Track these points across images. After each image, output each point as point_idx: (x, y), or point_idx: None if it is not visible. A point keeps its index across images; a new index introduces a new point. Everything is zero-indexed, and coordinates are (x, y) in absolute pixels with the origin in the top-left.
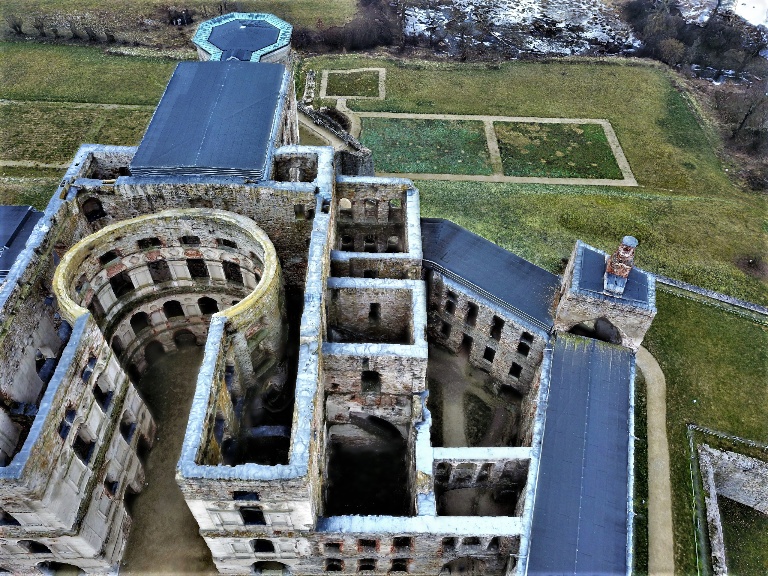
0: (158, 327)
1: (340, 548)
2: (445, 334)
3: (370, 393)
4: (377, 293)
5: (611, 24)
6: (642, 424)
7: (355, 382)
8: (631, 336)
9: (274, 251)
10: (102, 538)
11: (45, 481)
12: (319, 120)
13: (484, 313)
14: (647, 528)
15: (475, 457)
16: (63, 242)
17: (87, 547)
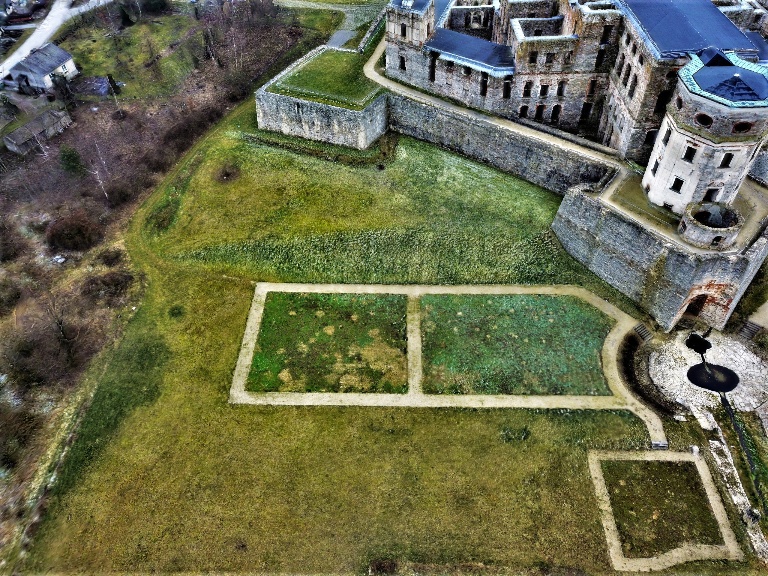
0: None
1: None
2: None
3: None
4: None
5: None
6: None
7: None
8: None
9: None
10: None
11: None
12: None
13: None
14: None
15: None
16: None
17: None
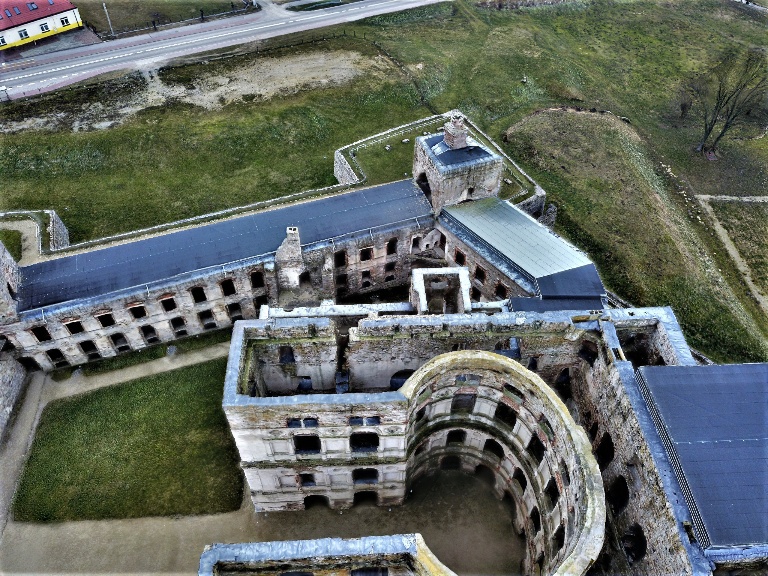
0: (504, 470)
1: None
2: None
3: None
4: None
5: None
6: None
7: None
8: None
9: None
10: (264, 489)
11: (245, 426)
12: None
13: None
14: None
15: None
16: (526, 342)
17: None
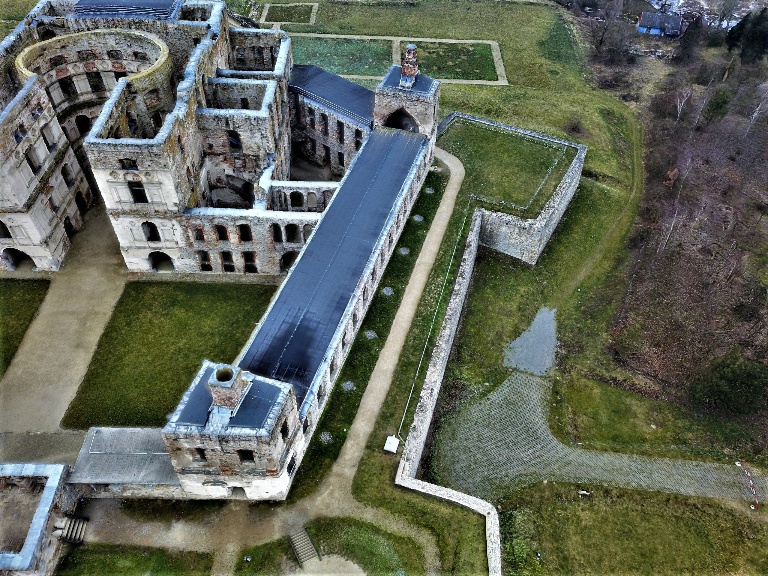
0: None
1: (204, 237)
2: (314, 151)
3: (236, 155)
4: (243, 88)
5: None
6: (439, 195)
7: (223, 142)
8: (423, 123)
9: (168, 50)
10: (46, 233)
11: (4, 158)
12: (244, 22)
13: (331, 121)
14: (423, 244)
15: (300, 185)
16: None
17: (35, 230)
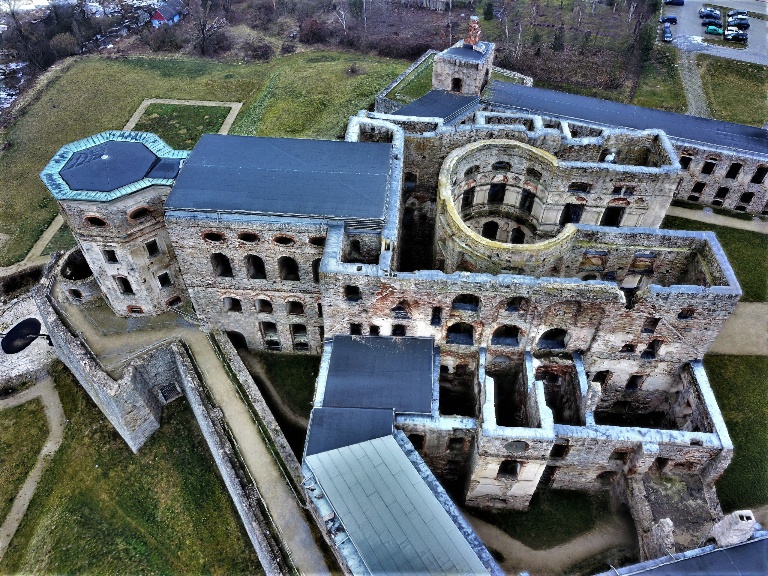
0: None
1: None
2: None
3: None
4: None
5: (6, 56)
6: None
7: None
8: None
9: None
10: None
11: None
12: None
13: None
14: None
15: None
16: None
17: None
